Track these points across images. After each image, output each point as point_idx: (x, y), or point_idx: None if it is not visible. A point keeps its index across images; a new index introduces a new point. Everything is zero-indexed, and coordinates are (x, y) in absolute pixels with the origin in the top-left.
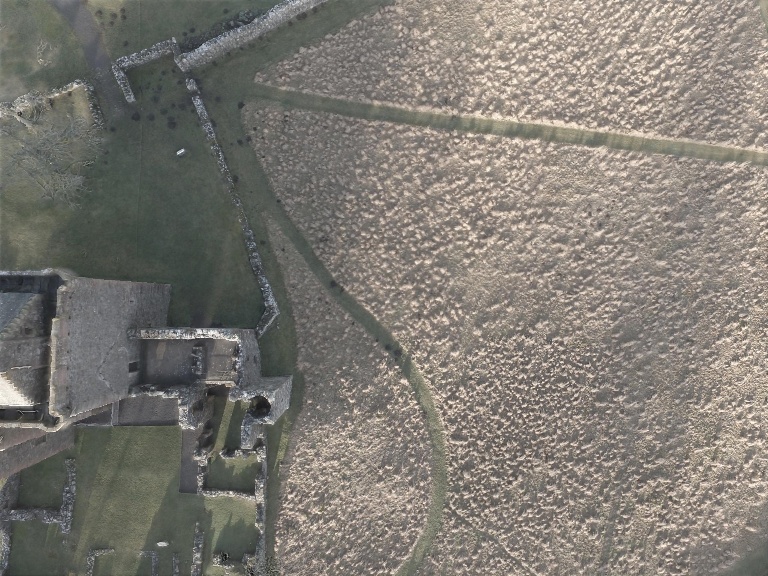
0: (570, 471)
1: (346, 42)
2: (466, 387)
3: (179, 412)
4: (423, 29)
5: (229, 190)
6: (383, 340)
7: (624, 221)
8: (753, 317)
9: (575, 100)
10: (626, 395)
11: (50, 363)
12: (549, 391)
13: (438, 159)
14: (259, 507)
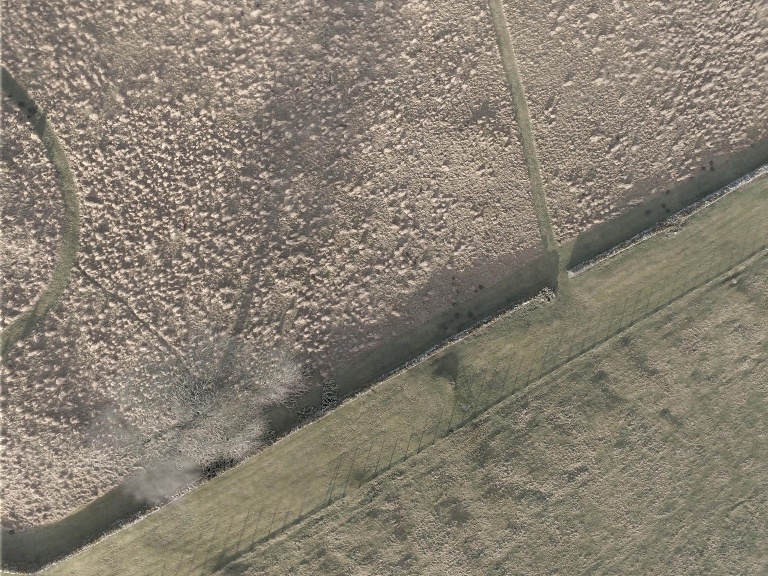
0: (209, 242)
1: None
2: (104, 151)
3: None
4: None
5: None
6: (17, 97)
7: (282, 4)
8: (410, 108)
9: None
10: (272, 172)
11: None
12: (193, 163)
13: None
14: None
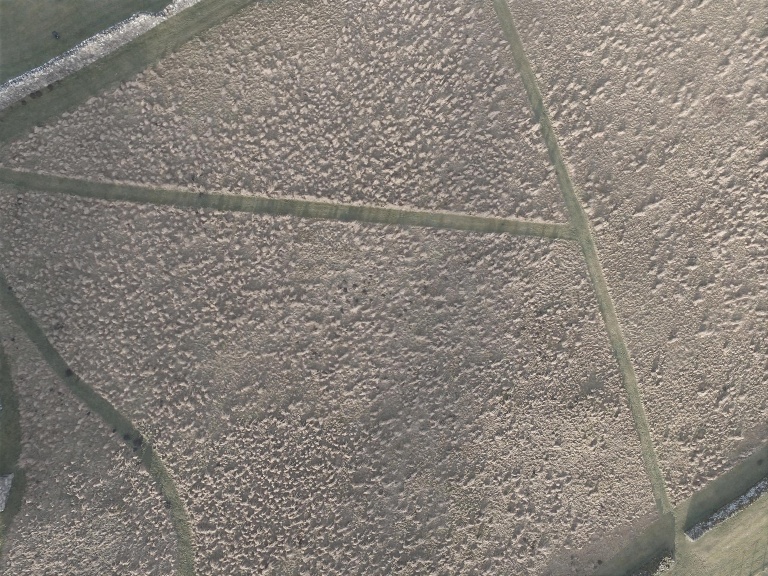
0: (325, 556)
1: (85, 120)
2: (213, 474)
3: None
4: (168, 104)
5: None
6: (122, 430)
7: (382, 296)
8: (518, 389)
9: (328, 174)
10: (384, 475)
11: None
12: (303, 474)
13: (184, 238)
14: None
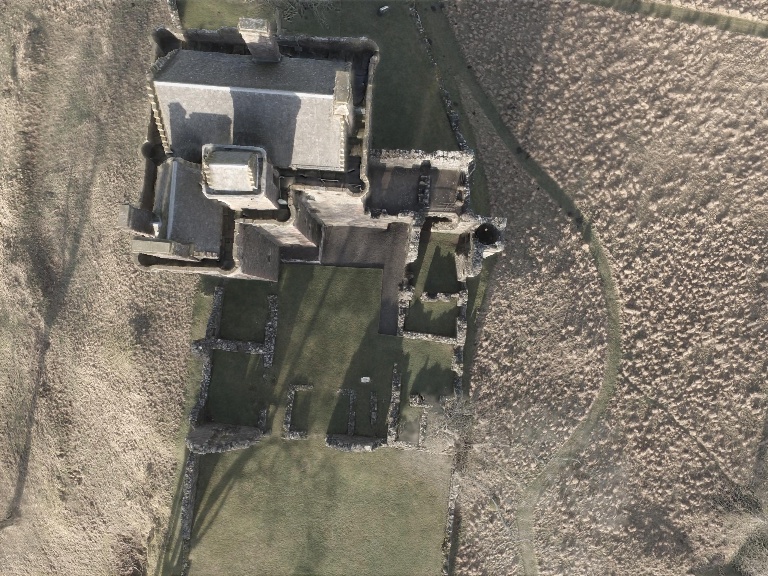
0: (736, 347)
1: None
2: (641, 259)
3: (411, 234)
4: None
5: (427, 50)
6: (566, 207)
7: None
8: None
9: None
10: None
11: (363, 127)
12: (718, 269)
13: (619, 39)
14: (456, 351)
